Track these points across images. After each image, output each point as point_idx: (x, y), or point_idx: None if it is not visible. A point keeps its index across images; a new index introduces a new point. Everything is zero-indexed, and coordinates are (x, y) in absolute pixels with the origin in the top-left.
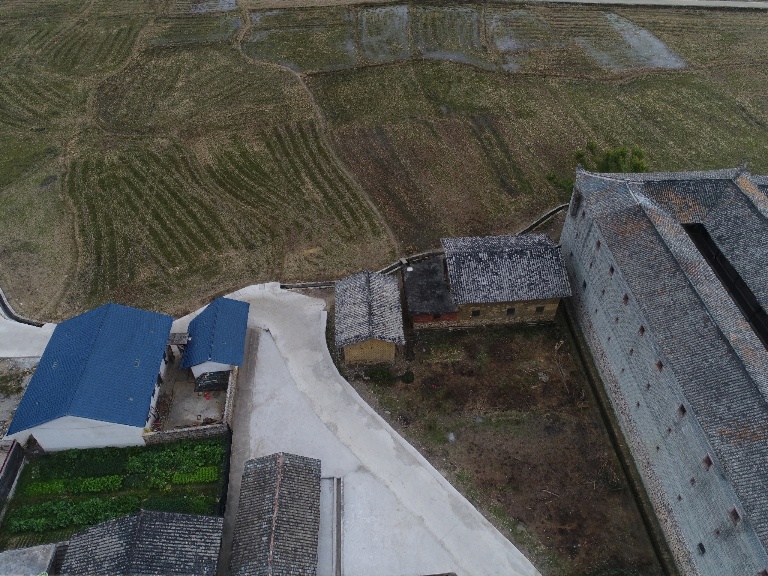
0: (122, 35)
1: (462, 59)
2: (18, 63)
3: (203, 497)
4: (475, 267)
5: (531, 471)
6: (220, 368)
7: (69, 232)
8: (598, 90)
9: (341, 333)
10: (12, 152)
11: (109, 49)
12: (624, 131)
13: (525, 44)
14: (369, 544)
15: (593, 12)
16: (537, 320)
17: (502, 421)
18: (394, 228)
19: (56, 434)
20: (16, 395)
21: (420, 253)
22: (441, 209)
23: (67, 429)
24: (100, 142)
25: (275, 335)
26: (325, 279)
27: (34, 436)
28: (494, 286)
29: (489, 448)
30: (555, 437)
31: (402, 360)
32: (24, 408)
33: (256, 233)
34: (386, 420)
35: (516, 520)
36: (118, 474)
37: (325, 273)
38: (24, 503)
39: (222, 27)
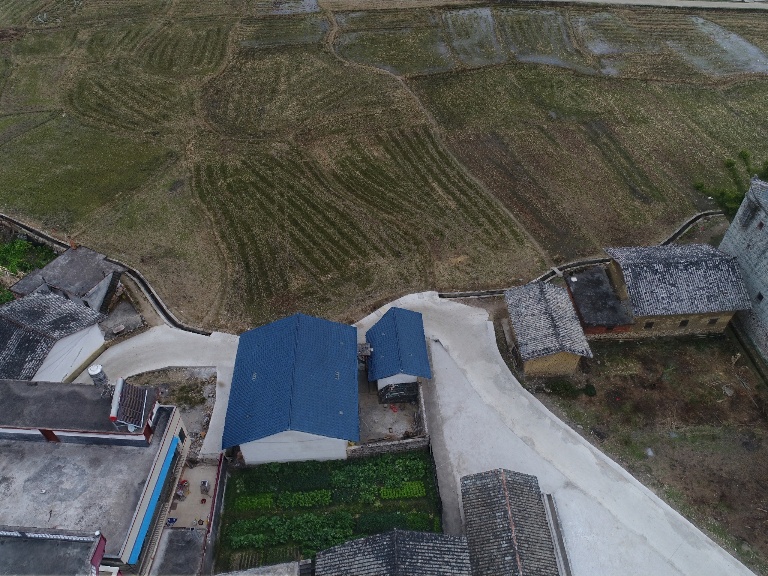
0: (212, 37)
1: (559, 63)
2: (115, 65)
3: (417, 513)
4: (652, 278)
5: (740, 488)
6: (406, 380)
7: (211, 238)
8: (703, 95)
9: (526, 345)
10: (132, 156)
11: (202, 51)
12: (741, 138)
13: (618, 48)
14: (597, 563)
15: (678, 15)
16: (706, 332)
17: (697, 436)
18: (535, 236)
19: (264, 448)
20: (201, 406)
21: (569, 262)
22: (578, 217)
23: (277, 443)
24: (218, 146)
25: (446, 346)
26: (481, 288)
27: (241, 449)
28: (673, 298)
29: (691, 464)
30: (755, 453)
31: (579, 372)
32: (233, 421)
33: (399, 240)
34: (580, 434)
35: (739, 539)
36: (325, 488)
37: (479, 282)
38: (238, 518)
39: (310, 29)
